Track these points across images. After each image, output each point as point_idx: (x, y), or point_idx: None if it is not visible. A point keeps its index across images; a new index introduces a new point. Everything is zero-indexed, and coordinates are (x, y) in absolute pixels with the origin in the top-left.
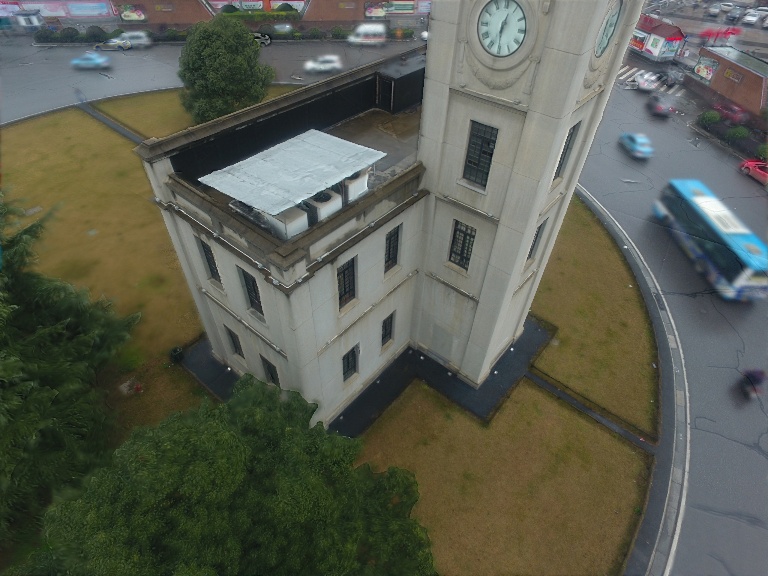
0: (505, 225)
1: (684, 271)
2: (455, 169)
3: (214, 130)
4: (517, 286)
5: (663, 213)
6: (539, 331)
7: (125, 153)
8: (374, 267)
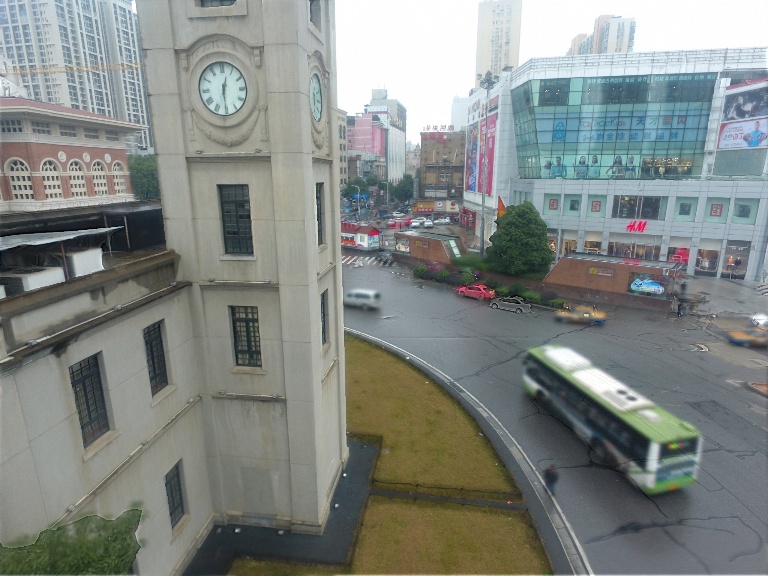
0: (286, 284)
1: (460, 361)
2: (214, 245)
3: None
4: (323, 374)
5: (423, 330)
6: (365, 447)
7: None
8: (133, 378)
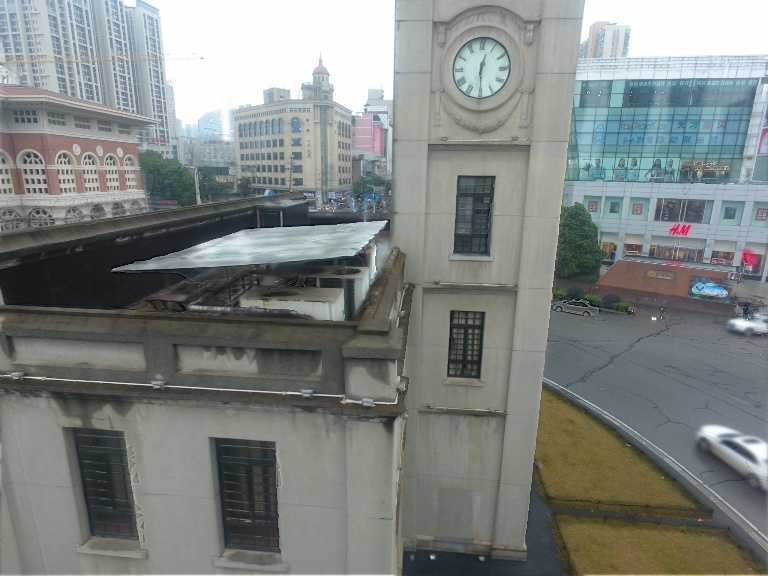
0: (527, 287)
1: (558, 366)
2: (445, 243)
3: (83, 234)
4: None
5: None
6: None
7: None
8: None
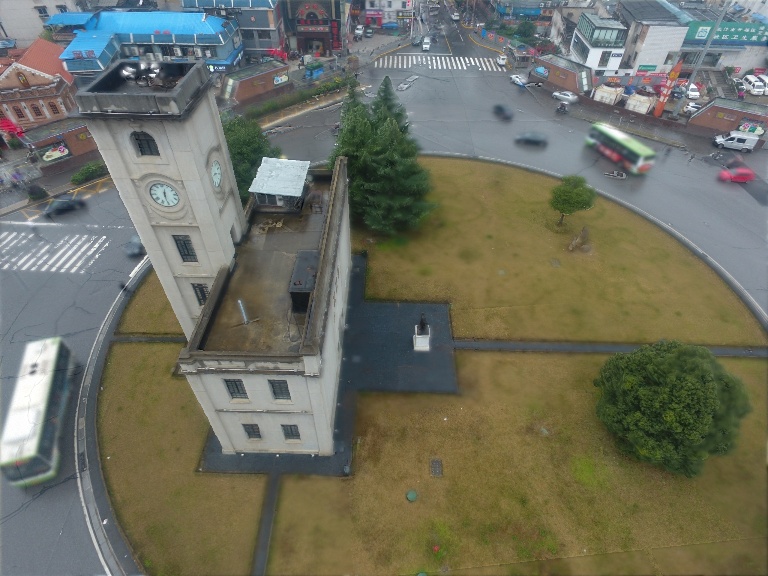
0: None
1: (42, 526)
2: None
3: None
4: None
5: None
6: None
7: (617, 329)
8: None
